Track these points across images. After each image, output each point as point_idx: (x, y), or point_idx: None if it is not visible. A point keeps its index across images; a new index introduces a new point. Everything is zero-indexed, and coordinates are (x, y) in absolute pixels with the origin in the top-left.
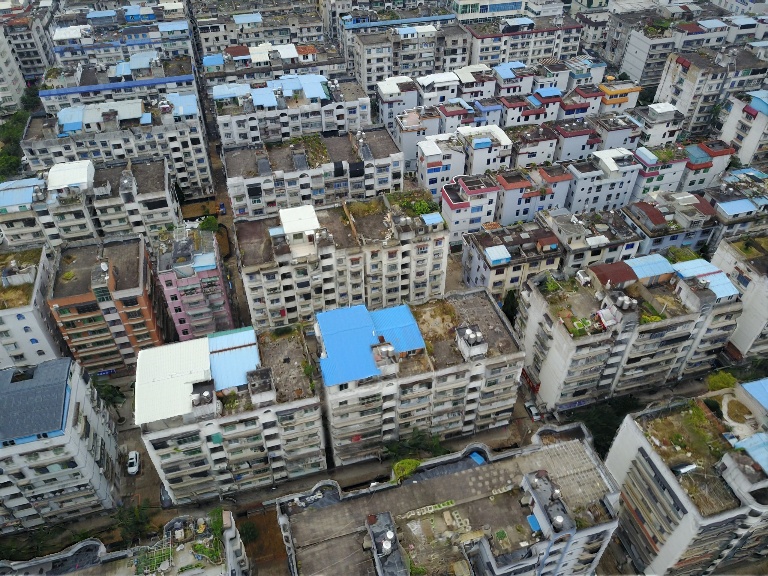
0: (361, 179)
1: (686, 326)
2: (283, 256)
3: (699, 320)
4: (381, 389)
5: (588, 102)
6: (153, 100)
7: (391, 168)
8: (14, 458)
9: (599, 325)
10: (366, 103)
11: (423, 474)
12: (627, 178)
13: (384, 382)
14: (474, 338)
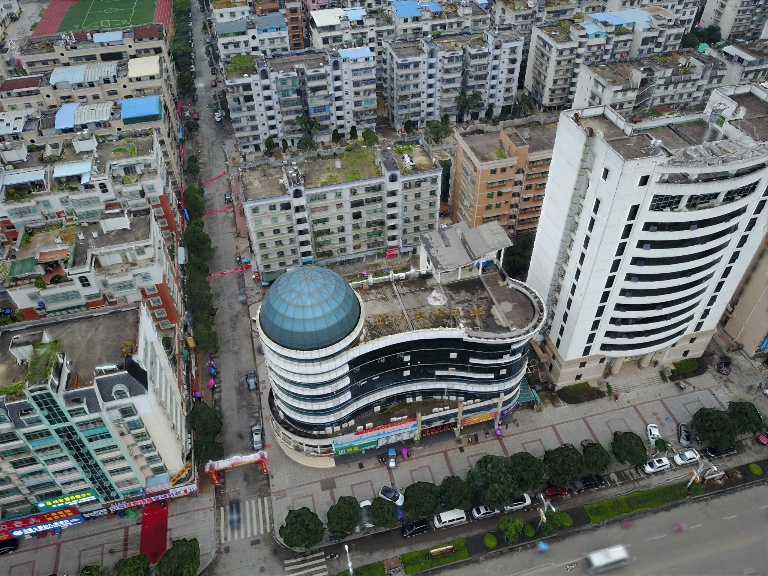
0: None
1: (571, 13)
2: None
3: (578, 10)
4: (422, 26)
5: None
6: None
7: None
8: (265, 41)
9: (527, 8)
10: None
11: None
12: None
13: (424, 21)
14: (465, 3)
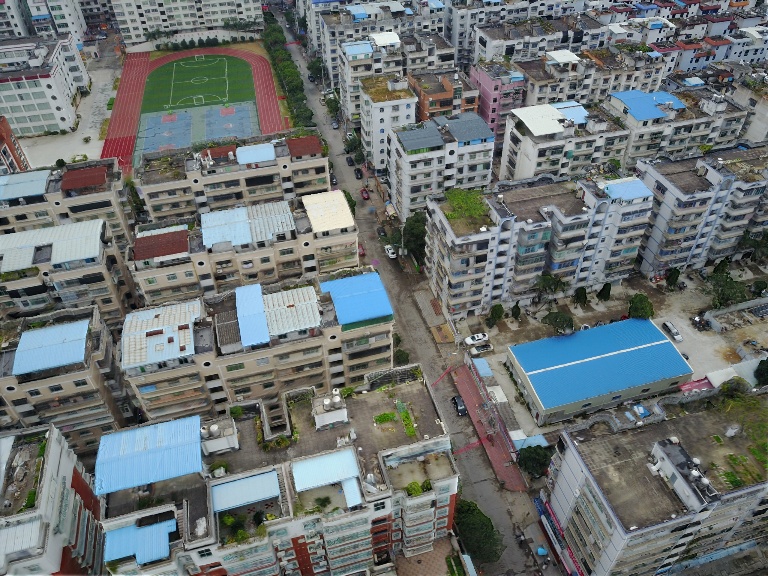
0: (579, 45)
1: None
2: (564, 73)
3: None
4: (664, 129)
5: (720, 4)
6: (402, 2)
7: (600, 37)
8: (464, 156)
9: None
10: (560, 2)
11: (714, 153)
12: (767, 45)
13: (667, 123)
14: (720, 98)
